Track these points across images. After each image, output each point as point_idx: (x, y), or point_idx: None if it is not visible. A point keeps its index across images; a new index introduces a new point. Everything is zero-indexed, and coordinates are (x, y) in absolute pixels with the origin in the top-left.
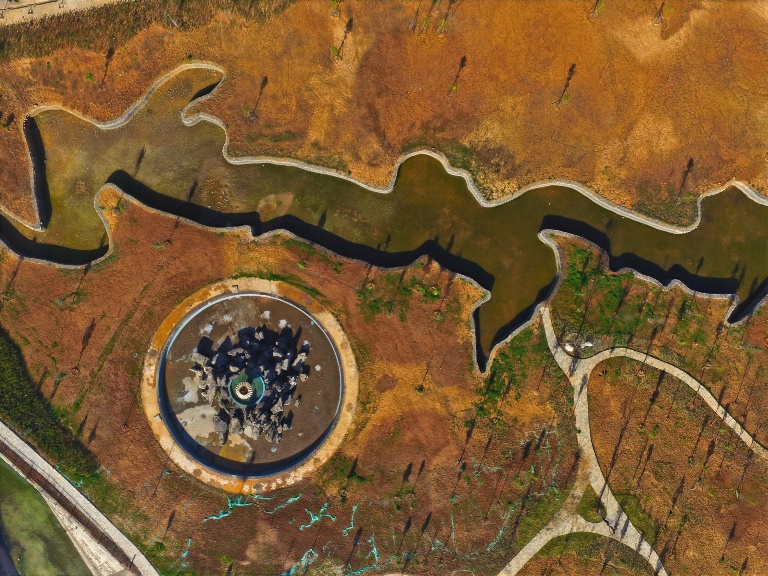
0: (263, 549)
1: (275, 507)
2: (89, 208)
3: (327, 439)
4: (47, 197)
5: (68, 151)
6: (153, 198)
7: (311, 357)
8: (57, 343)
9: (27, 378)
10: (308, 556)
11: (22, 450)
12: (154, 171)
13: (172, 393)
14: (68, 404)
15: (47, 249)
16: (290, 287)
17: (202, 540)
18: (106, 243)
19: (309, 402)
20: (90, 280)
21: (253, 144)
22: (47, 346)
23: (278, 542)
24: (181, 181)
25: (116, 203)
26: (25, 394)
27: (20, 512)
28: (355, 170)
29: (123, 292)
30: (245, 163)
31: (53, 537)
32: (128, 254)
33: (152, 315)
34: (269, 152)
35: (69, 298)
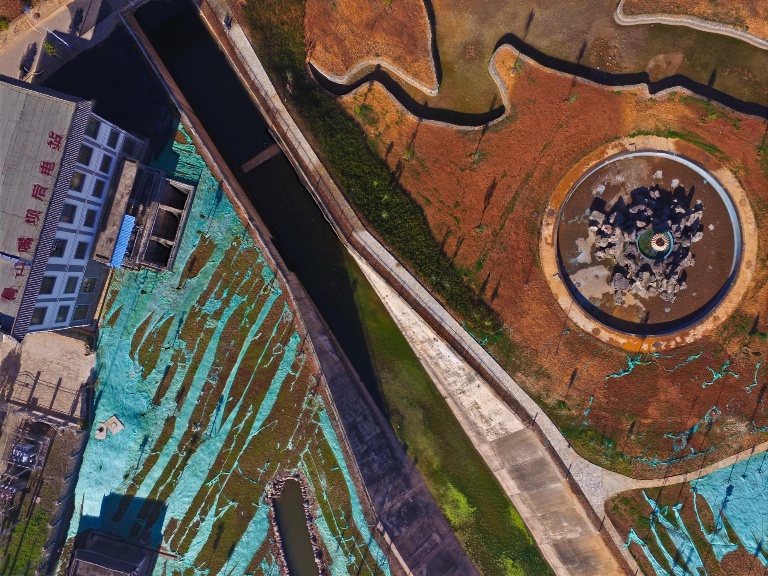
0: (665, 407)
1: (676, 365)
2: (479, 72)
3: (726, 297)
4: (438, 62)
5: (458, 16)
6: (543, 60)
7: (704, 216)
8: (459, 203)
9: (431, 237)
10: (711, 413)
11: (432, 307)
12: (543, 34)
13: (565, 254)
14: (471, 263)
15: (438, 113)
16: (687, 144)
17: (604, 398)
18: (496, 106)
19: (703, 262)
20: (488, 140)
21: (649, 2)
22: (449, 206)
23: (680, 400)
24: (570, 43)
25: (513, 63)
26: (432, 252)
27: (399, 380)
28: (753, 25)
29: (523, 151)
30: (635, 23)
31: (432, 404)
32: (527, 114)
33: (550, 174)
34: (665, 9)
35: (468, 158)
